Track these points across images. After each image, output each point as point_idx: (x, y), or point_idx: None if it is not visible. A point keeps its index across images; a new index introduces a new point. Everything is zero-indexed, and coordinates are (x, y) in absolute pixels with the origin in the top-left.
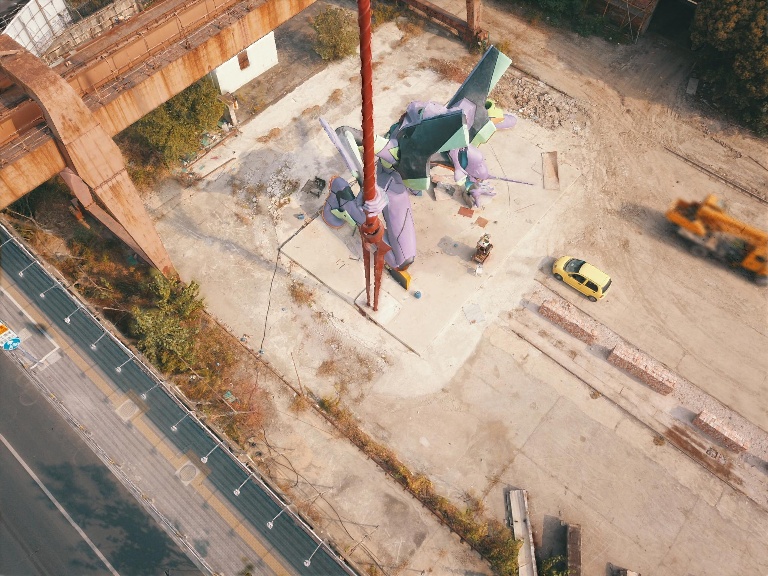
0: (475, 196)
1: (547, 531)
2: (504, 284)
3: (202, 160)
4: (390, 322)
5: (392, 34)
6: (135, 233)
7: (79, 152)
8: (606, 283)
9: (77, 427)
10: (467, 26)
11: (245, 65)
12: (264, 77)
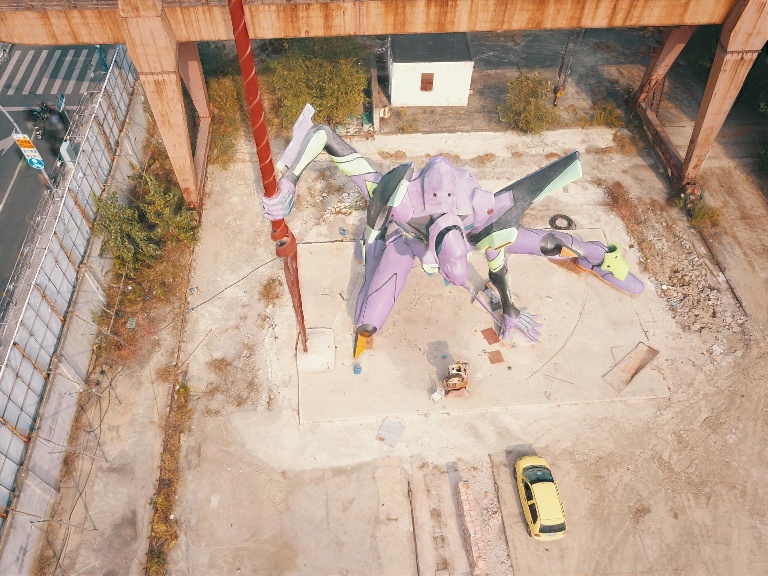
0: (506, 324)
1: None
2: (452, 432)
3: None
4: (308, 372)
5: (600, 139)
6: (167, 137)
7: (133, 31)
8: (552, 523)
9: (30, 258)
10: (681, 170)
11: (428, 88)
12: (442, 110)
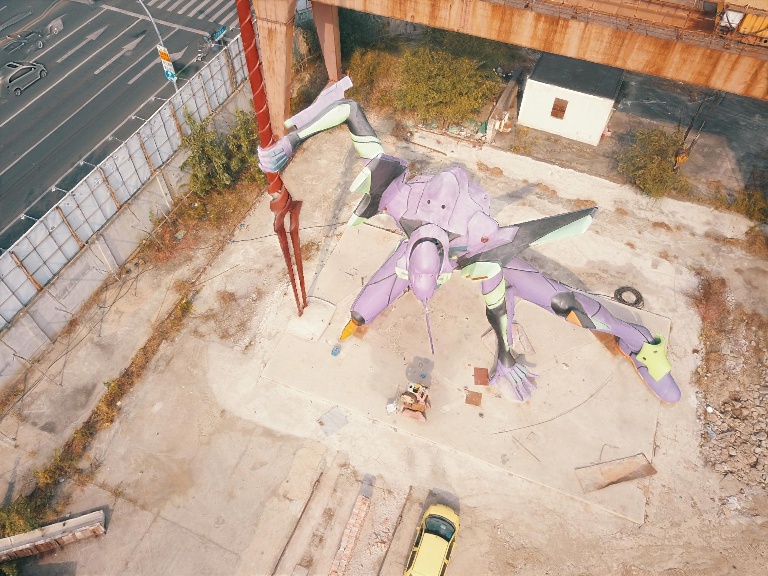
0: (497, 370)
1: (57, 568)
2: (389, 448)
3: (431, 135)
4: (293, 335)
5: (730, 227)
6: (269, 83)
7: None
8: None
9: None
10: None
11: (559, 115)
12: (568, 142)
